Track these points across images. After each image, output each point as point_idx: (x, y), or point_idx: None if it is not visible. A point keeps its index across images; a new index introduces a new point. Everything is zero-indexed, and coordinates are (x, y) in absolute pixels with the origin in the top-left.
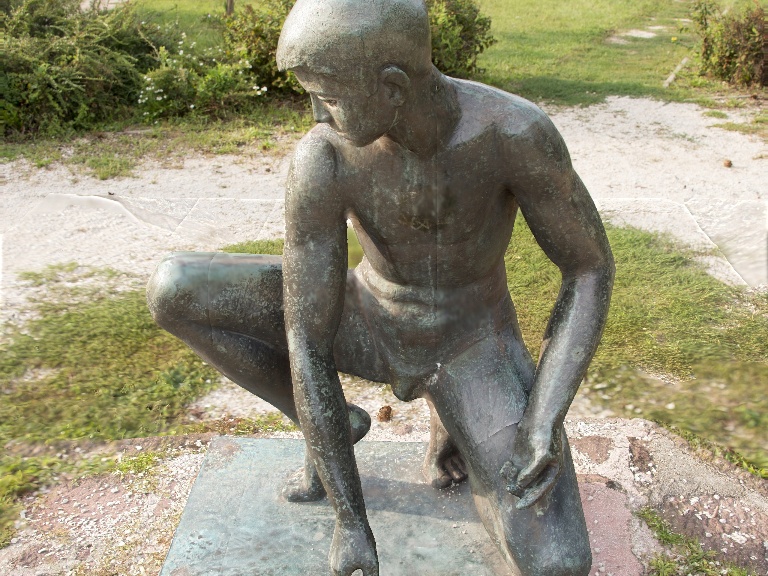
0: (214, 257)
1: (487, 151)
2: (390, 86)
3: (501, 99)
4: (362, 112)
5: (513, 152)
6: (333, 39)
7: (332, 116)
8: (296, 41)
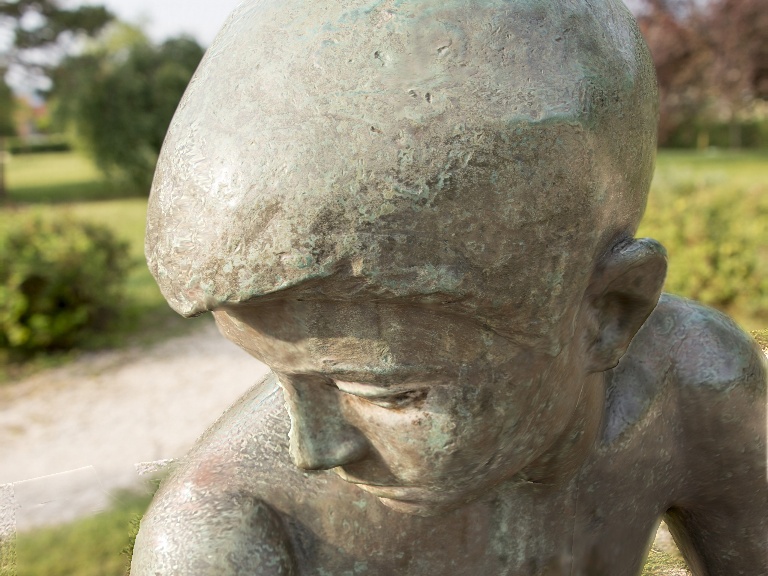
0: None
1: (669, 434)
2: (600, 307)
3: (667, 303)
4: (519, 413)
5: (728, 424)
6: (472, 149)
7: (368, 441)
8: (289, 180)
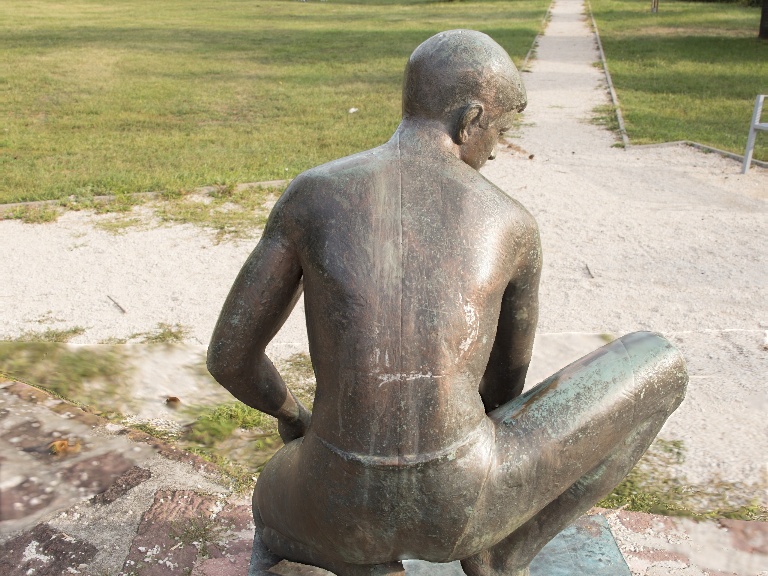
0: (622, 344)
1: None
2: None
3: None
4: None
5: None
6: None
7: None
8: None
